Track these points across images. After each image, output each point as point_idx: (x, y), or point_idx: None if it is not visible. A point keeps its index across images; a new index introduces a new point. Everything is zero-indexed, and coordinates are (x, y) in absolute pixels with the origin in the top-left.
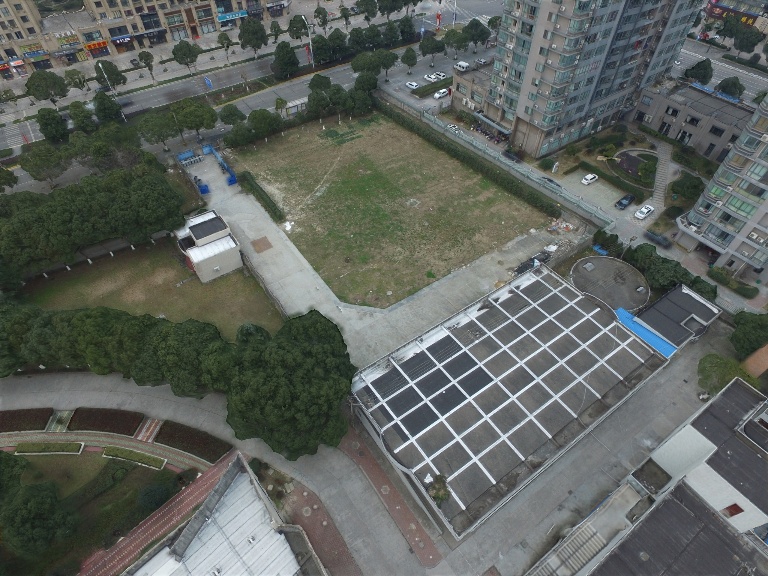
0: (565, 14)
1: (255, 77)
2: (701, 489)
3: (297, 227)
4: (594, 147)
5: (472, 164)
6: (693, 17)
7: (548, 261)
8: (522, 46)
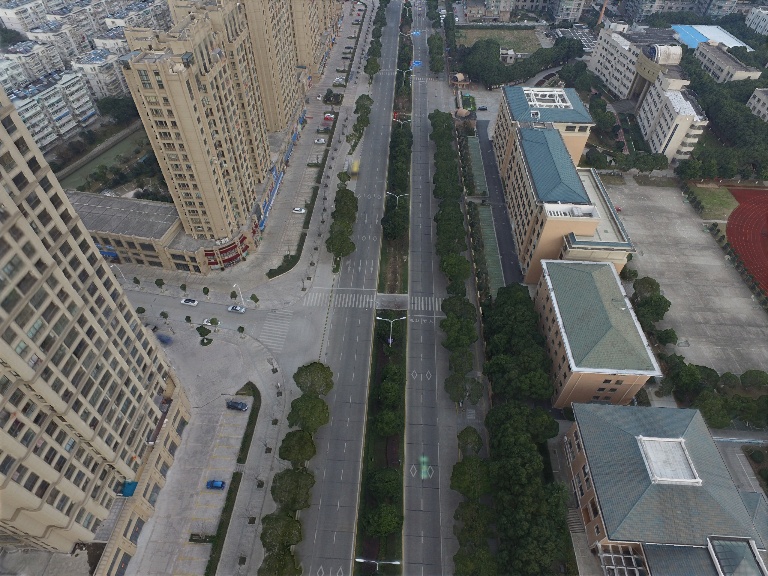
0: None
1: (397, 36)
2: None
3: None
4: (514, 15)
5: None
6: None
7: (551, 32)
8: None
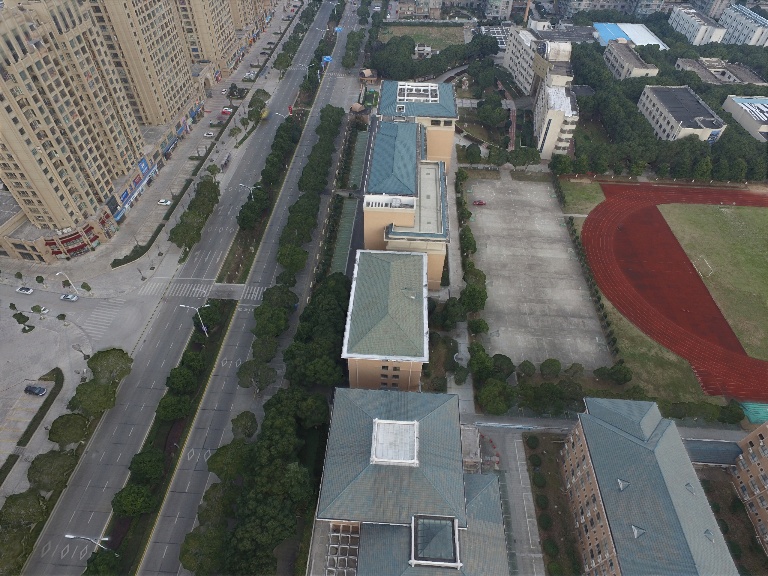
0: None
1: (324, 32)
2: (539, 28)
3: None
4: None
5: (431, 24)
6: None
7: None
8: None
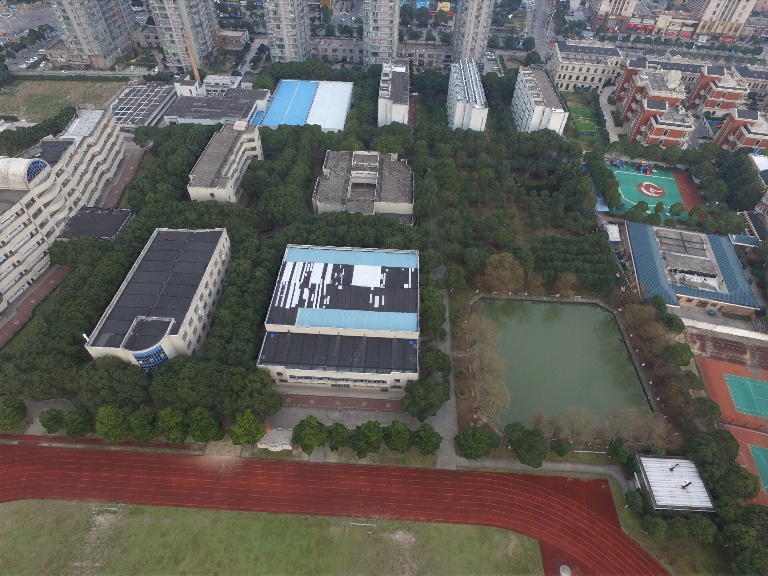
0: (77, 8)
1: None
2: None
3: (28, 119)
4: (127, 58)
5: (83, 79)
6: (128, 0)
7: None
8: (69, 25)
